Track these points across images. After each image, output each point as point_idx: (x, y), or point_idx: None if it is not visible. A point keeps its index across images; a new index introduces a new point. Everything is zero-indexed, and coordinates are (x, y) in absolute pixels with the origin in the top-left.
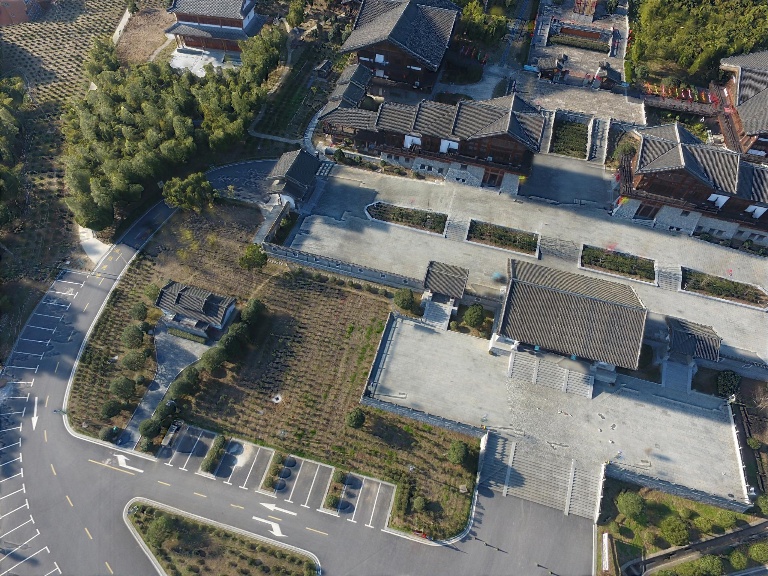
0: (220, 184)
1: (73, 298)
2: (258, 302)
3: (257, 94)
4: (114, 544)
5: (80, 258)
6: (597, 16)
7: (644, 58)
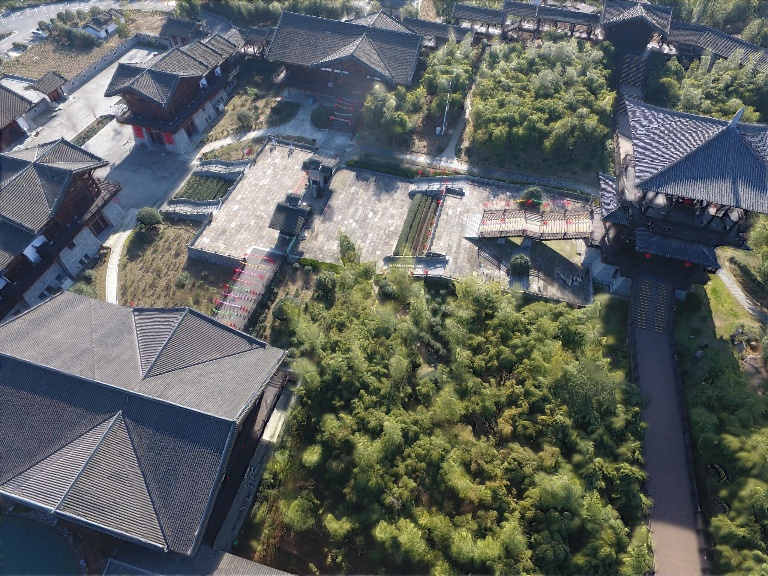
0: (214, 26)
1: (143, 3)
2: (92, 37)
3: (273, 6)
4: (2, 31)
5: (171, 0)
6: (492, 249)
7: (382, 304)
